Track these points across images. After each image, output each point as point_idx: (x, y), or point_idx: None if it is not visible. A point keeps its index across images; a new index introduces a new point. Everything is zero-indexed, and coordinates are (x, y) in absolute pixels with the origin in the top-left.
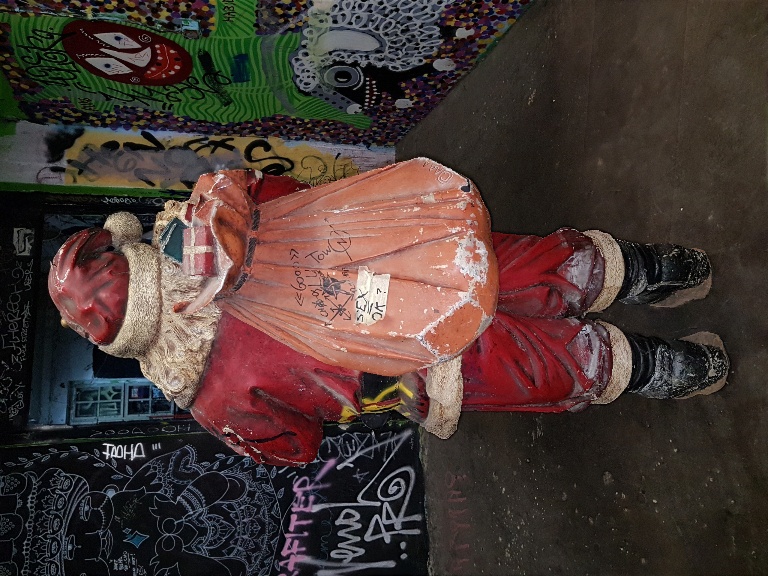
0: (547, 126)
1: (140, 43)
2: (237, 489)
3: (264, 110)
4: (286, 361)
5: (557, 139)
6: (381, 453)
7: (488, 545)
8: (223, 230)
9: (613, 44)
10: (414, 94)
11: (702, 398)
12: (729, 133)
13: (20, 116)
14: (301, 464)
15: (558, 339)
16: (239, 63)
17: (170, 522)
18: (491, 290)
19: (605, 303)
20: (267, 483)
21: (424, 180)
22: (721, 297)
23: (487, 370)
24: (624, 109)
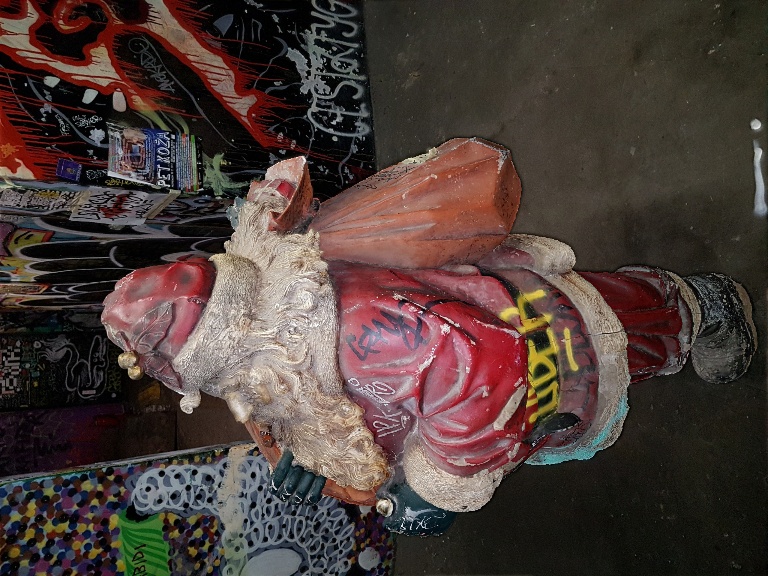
0: None
1: None
2: None
3: None
4: None
5: None
6: None
7: None
8: None
9: None
10: None
11: (760, 323)
12: None
13: None
14: (516, 339)
15: None
16: None
17: None
18: None
19: None
20: None
21: None
22: None
23: None
24: None
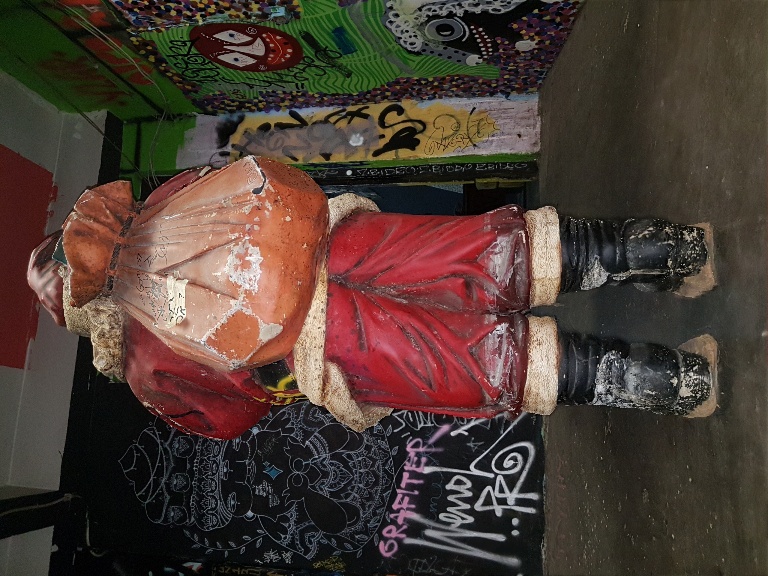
0: (633, 59)
1: (250, 35)
2: (356, 441)
3: (385, 76)
4: None
5: (638, 75)
6: (498, 425)
7: (574, 541)
8: (77, 240)
9: None
10: (533, 33)
11: (710, 420)
12: (738, 60)
13: (197, 111)
14: None
15: (462, 339)
16: (340, 36)
17: (299, 462)
18: (268, 297)
19: (546, 296)
20: (383, 440)
21: (238, 182)
22: (726, 290)
23: (374, 369)
24: (678, 32)
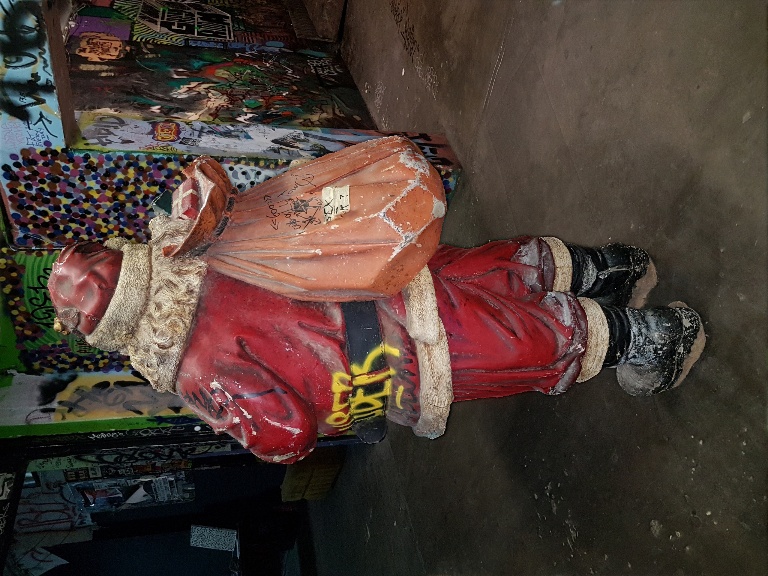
0: None
1: None
2: None
3: None
4: (270, 317)
5: None
6: None
7: None
8: (206, 177)
9: (518, 174)
10: None
11: (697, 372)
12: (617, 163)
13: (18, 368)
14: (295, 434)
15: None
16: None
17: None
18: (436, 183)
19: (564, 286)
20: None
21: None
22: (668, 276)
23: (466, 324)
24: (541, 207)
